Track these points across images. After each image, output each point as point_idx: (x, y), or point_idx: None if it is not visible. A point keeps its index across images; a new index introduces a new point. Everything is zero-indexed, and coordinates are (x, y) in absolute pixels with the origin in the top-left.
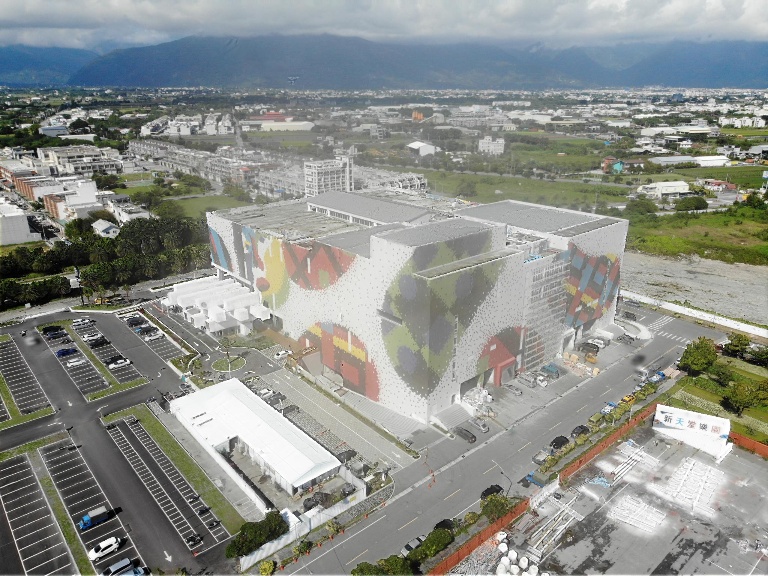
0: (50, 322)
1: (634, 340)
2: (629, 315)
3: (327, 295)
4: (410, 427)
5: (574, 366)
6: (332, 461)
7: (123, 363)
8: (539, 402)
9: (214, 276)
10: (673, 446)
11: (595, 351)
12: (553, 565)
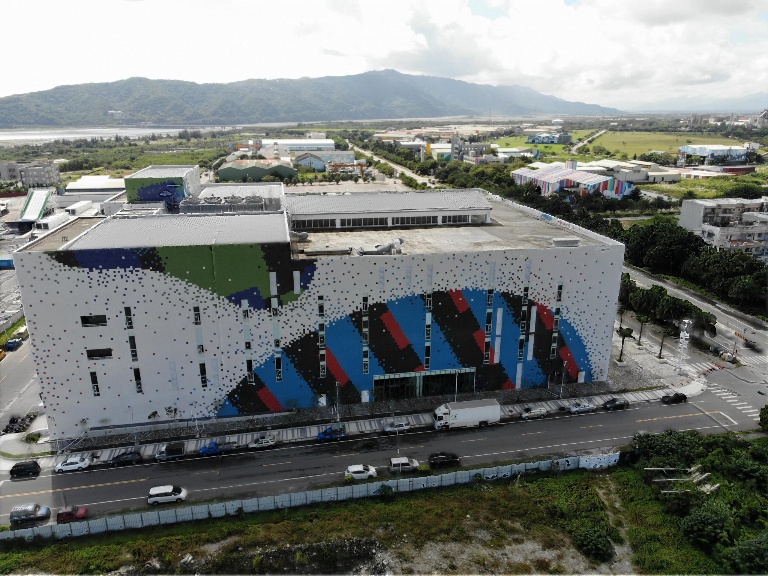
0: None
1: (6, 429)
2: None
3: None
4: None
5: None
6: None
7: None
8: None
9: None
10: None
11: None
12: None
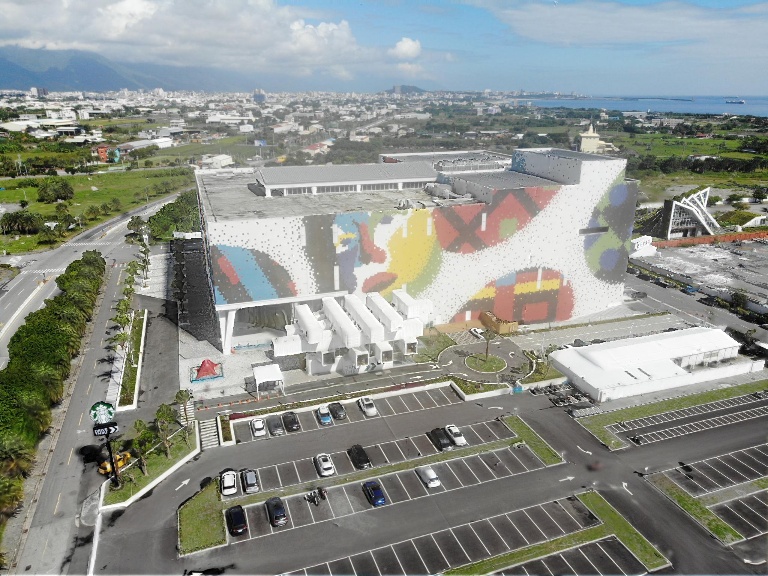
0: (168, 534)
1: None
2: None
3: (511, 244)
4: (624, 310)
5: None
6: None
7: None
8: None
9: (303, 305)
10: None
11: None
12: None
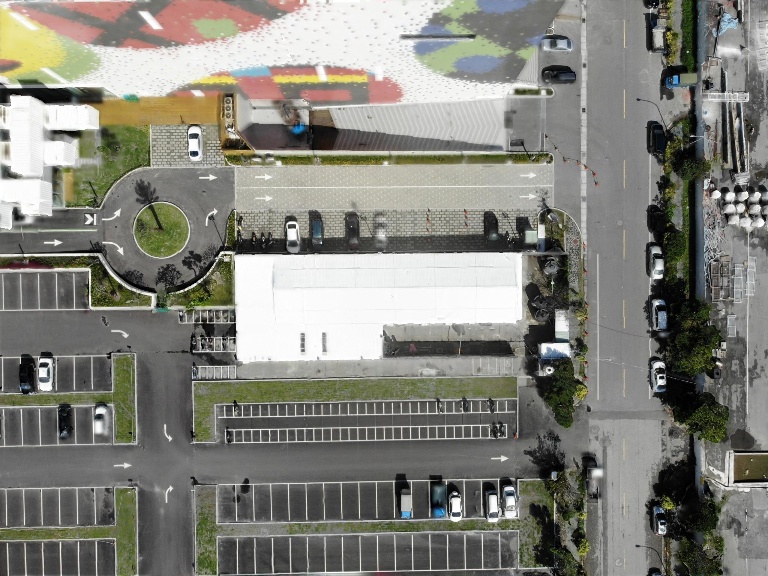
0: None
1: None
2: None
3: (237, 44)
4: (491, 118)
5: None
6: (515, 262)
7: (49, 370)
8: None
9: None
10: None
11: None
12: (759, 173)
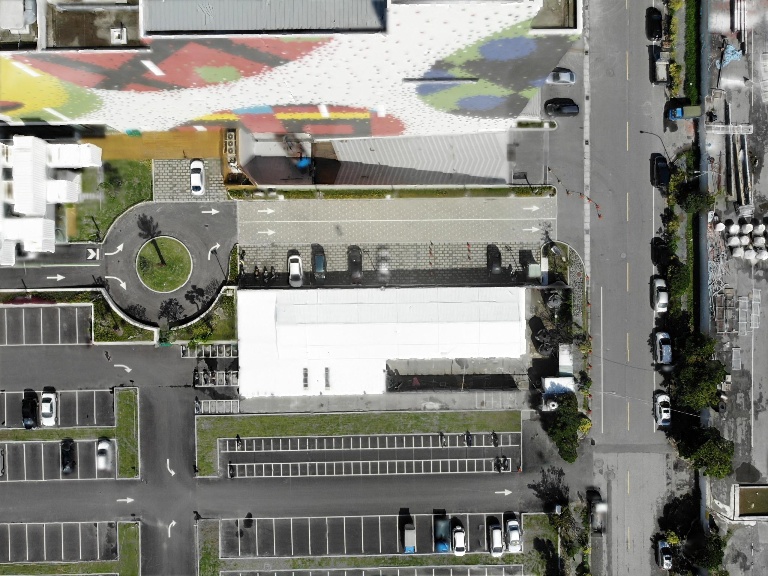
0: None
1: None
2: None
3: (239, 87)
4: (494, 151)
5: None
6: (518, 296)
7: (52, 405)
8: None
9: None
10: None
11: None
12: (763, 206)
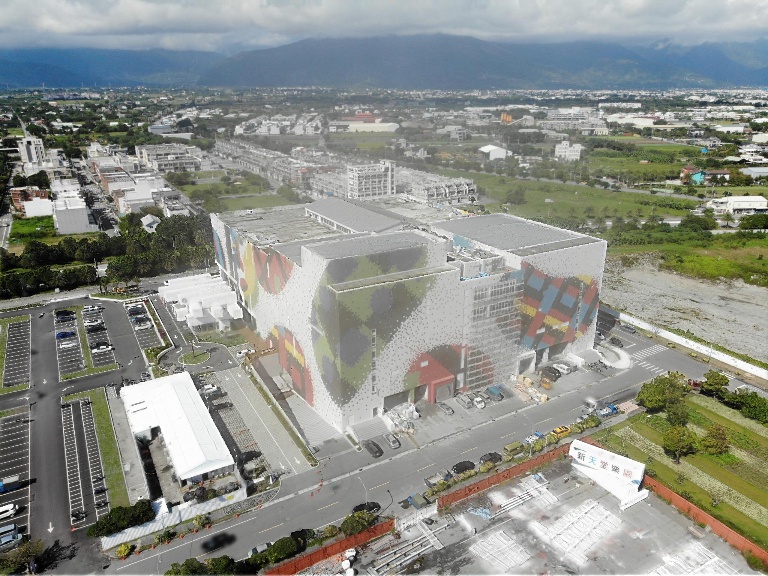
0: (68, 306)
1: (607, 368)
2: (615, 341)
3: (280, 300)
4: (326, 435)
5: (524, 390)
6: (226, 459)
7: (105, 349)
8: (467, 424)
9: (208, 274)
10: (583, 485)
11: (553, 376)
12: None
